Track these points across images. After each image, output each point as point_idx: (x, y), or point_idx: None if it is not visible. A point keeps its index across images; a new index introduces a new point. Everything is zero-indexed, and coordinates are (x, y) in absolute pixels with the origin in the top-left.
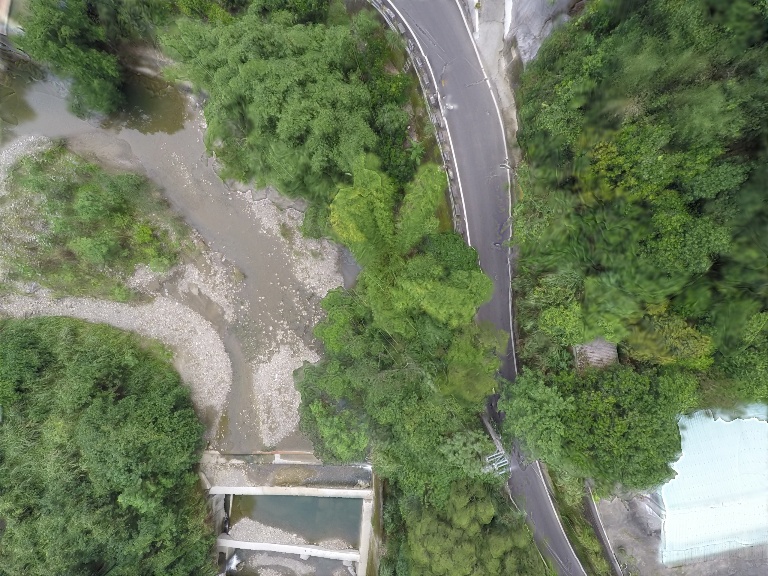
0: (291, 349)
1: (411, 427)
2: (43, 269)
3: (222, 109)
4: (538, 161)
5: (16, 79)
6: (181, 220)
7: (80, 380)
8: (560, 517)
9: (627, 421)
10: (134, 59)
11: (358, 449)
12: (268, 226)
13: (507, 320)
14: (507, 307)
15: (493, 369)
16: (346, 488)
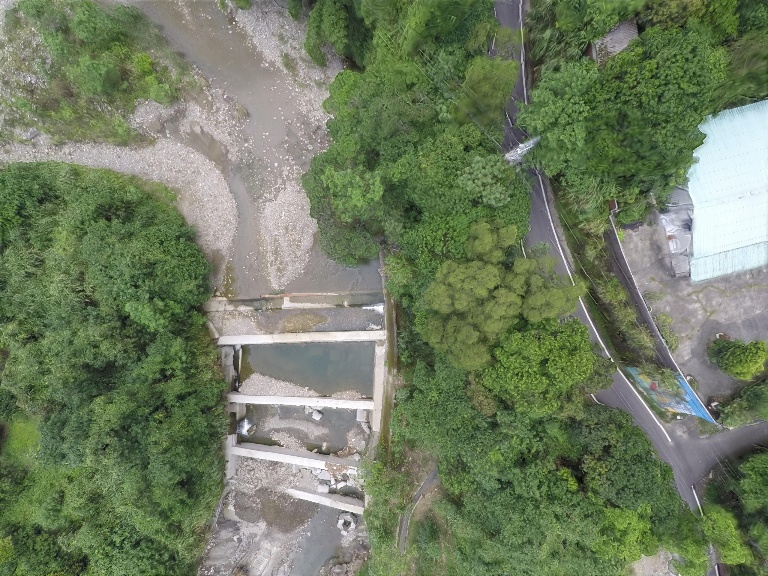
0: (297, 185)
1: (428, 166)
2: (40, 107)
3: None
4: None
5: None
6: (180, 57)
7: (82, 205)
8: None
9: (655, 62)
10: None
11: (374, 199)
12: (270, 58)
13: (520, 83)
14: (520, 69)
15: None
16: (358, 330)
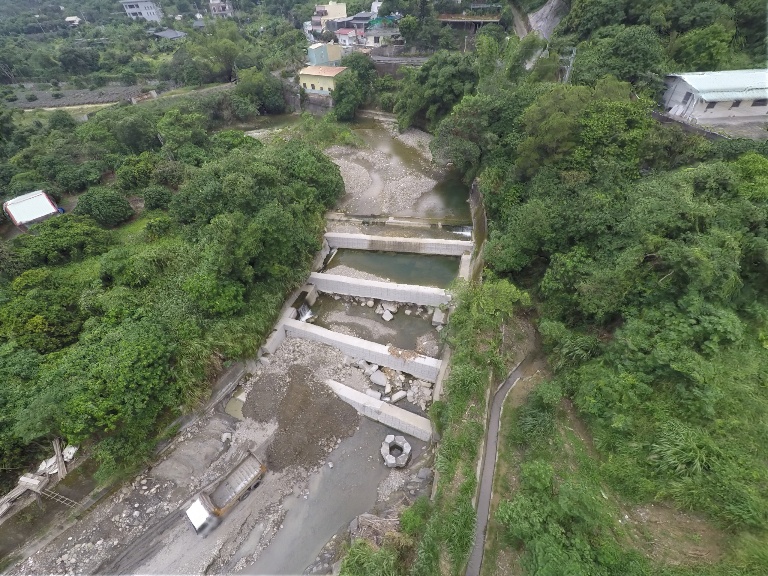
0: (415, 177)
1: None
2: None
3: None
4: (559, 28)
5: None
6: None
7: None
8: None
9: None
10: (365, 107)
11: None
12: (411, 146)
13: None
14: None
15: None
16: None
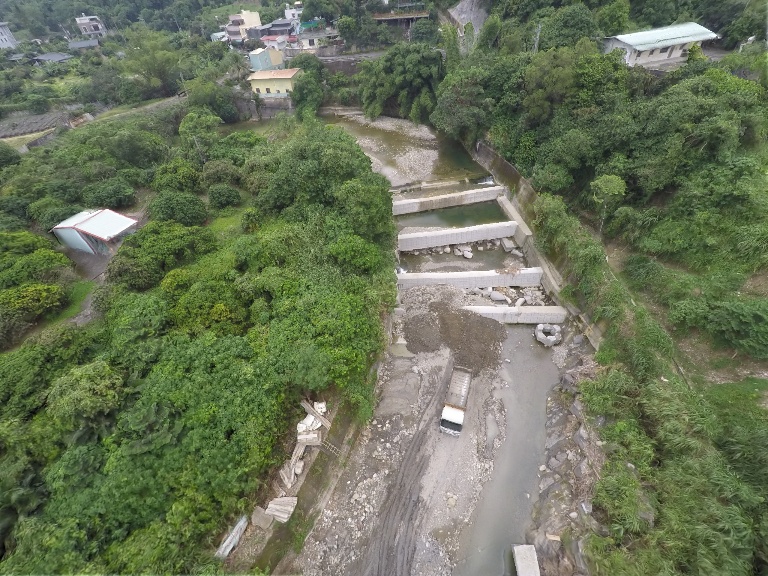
0: (416, 151)
1: None
2: None
3: None
4: None
5: (262, 120)
6: None
7: None
8: None
9: None
10: (323, 104)
11: None
12: None
13: None
14: None
15: None
16: None
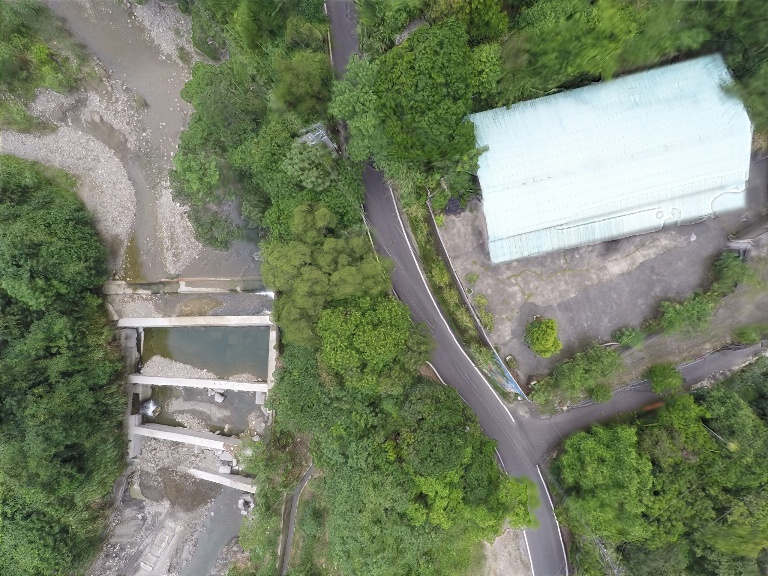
0: None
1: (257, 152)
2: None
3: None
4: None
5: None
6: (82, 49)
7: None
8: (425, 276)
9: (413, 53)
10: None
11: (210, 182)
12: (167, 52)
13: None
14: None
15: (317, 62)
16: (250, 314)
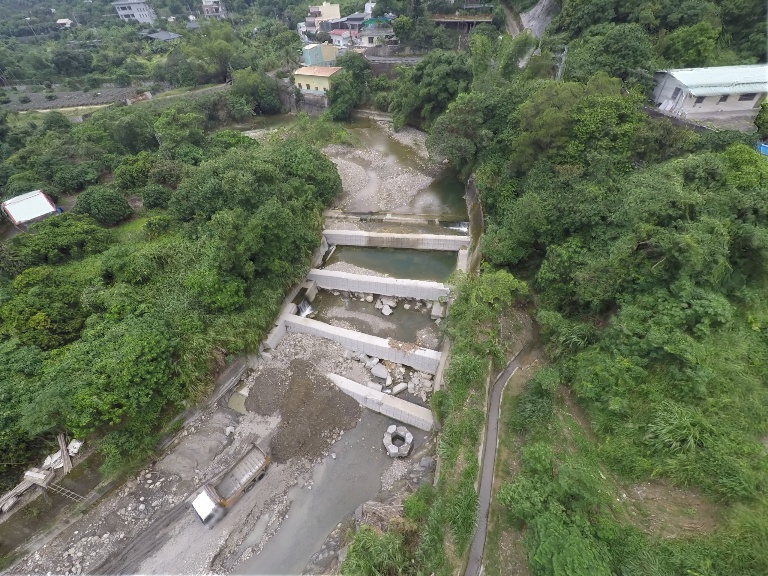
0: (412, 174)
1: None
2: None
3: (420, 63)
4: None
5: None
6: None
7: None
8: None
9: None
10: (360, 106)
11: None
12: (407, 144)
13: None
14: None
15: None
16: None
